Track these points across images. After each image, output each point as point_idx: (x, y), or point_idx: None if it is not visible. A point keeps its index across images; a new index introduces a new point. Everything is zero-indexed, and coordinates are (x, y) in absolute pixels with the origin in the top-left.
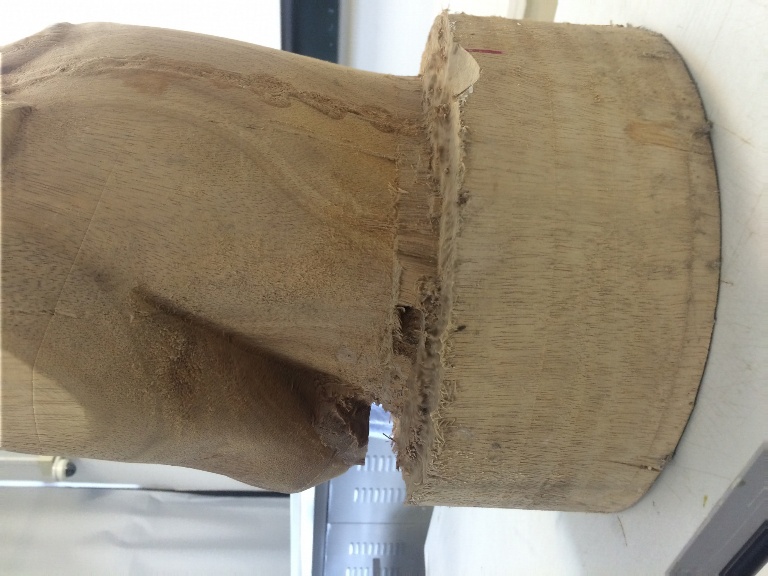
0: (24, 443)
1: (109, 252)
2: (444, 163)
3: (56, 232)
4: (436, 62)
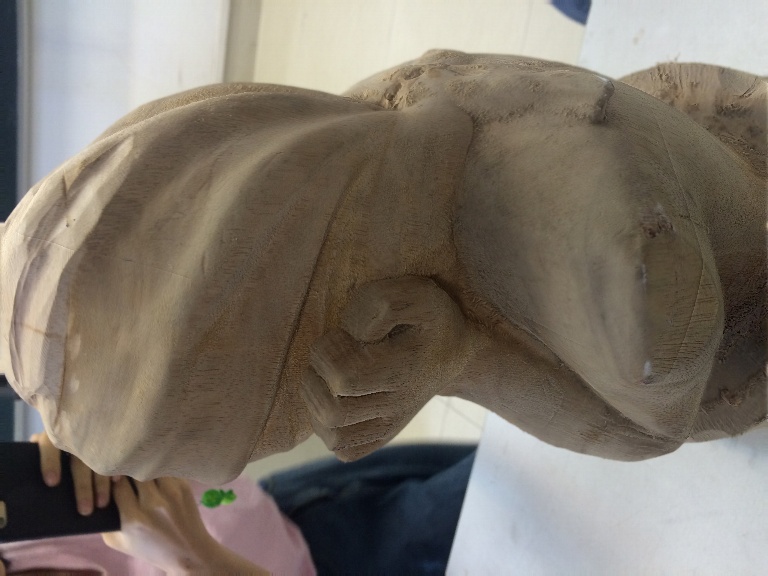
0: (667, 359)
1: (684, 177)
2: (759, 134)
3: (661, 158)
4: (668, 94)
